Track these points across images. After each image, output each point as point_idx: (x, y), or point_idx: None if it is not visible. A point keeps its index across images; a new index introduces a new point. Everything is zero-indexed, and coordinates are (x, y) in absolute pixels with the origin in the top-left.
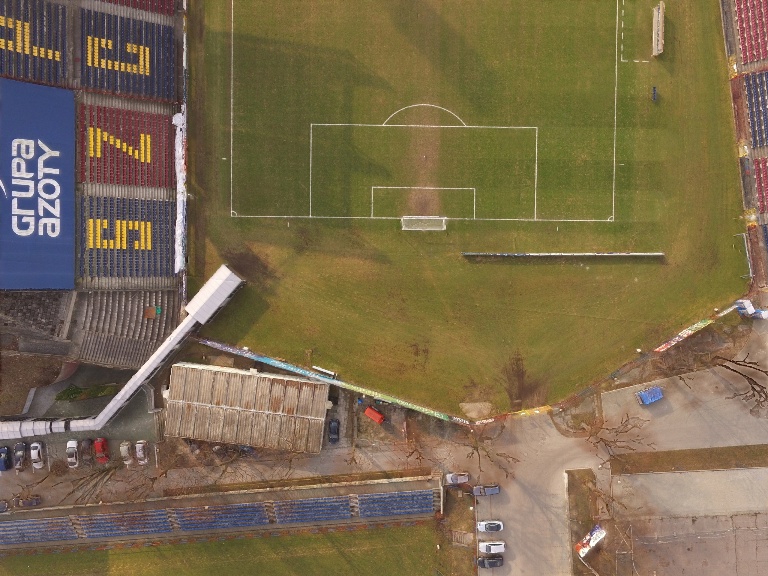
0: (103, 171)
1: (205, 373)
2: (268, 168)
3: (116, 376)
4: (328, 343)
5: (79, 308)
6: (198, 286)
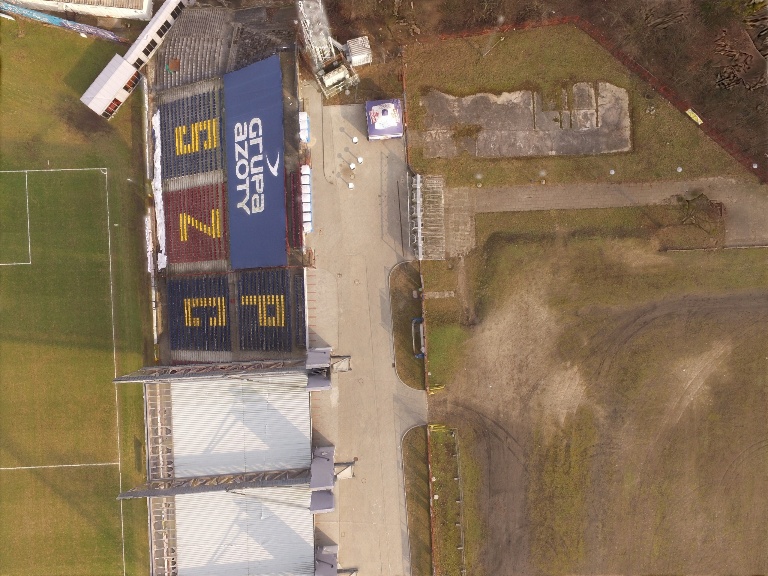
0: (210, 197)
1: (110, 3)
2: (72, 218)
3: (216, 4)
4: (2, 44)
5: (226, 60)
6: (137, 98)
